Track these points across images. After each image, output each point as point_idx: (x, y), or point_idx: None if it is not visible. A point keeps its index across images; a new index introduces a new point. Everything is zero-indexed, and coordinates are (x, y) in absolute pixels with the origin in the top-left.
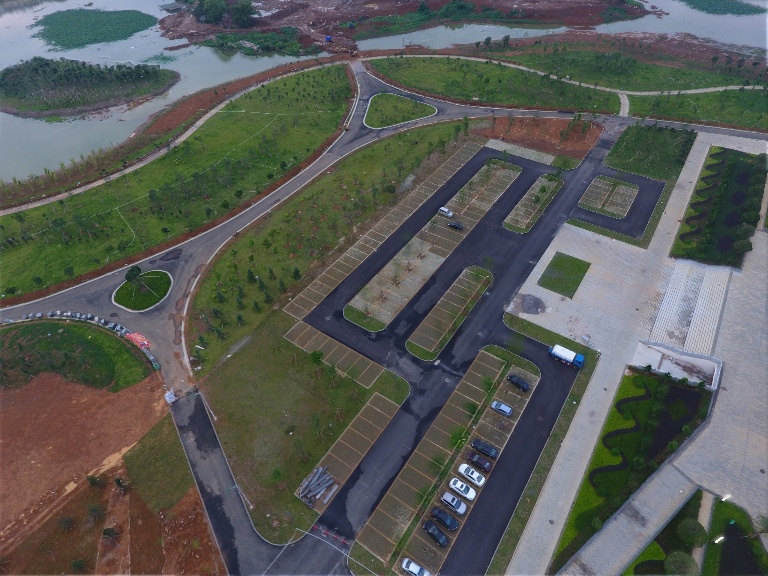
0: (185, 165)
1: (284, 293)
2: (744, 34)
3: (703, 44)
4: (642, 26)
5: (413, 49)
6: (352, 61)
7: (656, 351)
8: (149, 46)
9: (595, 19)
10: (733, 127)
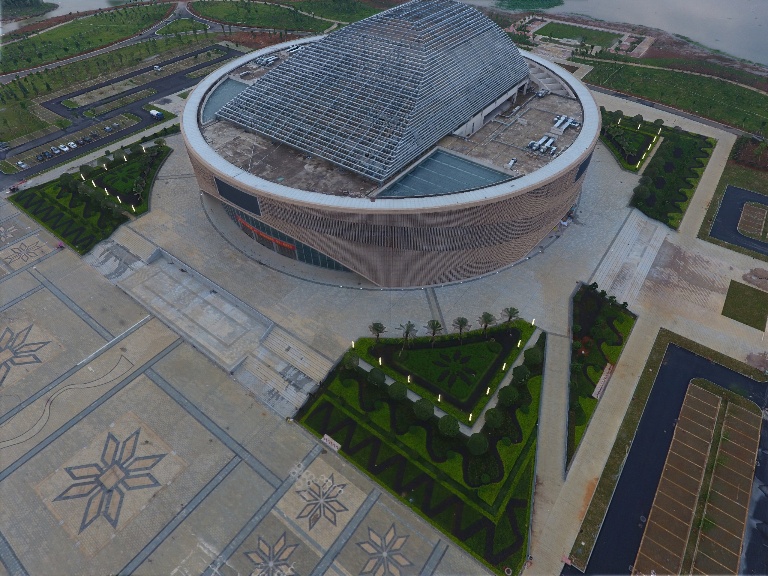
0: None
1: (37, 95)
2: None
3: None
4: None
5: None
6: (182, 2)
7: None
8: None
9: None
10: None
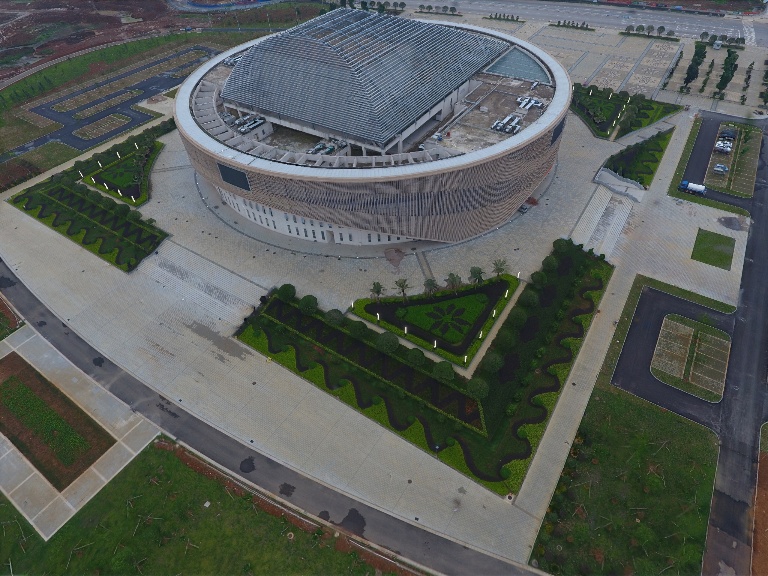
0: None
1: None
2: None
3: None
4: None
5: None
6: None
7: None
8: None
9: None
10: None
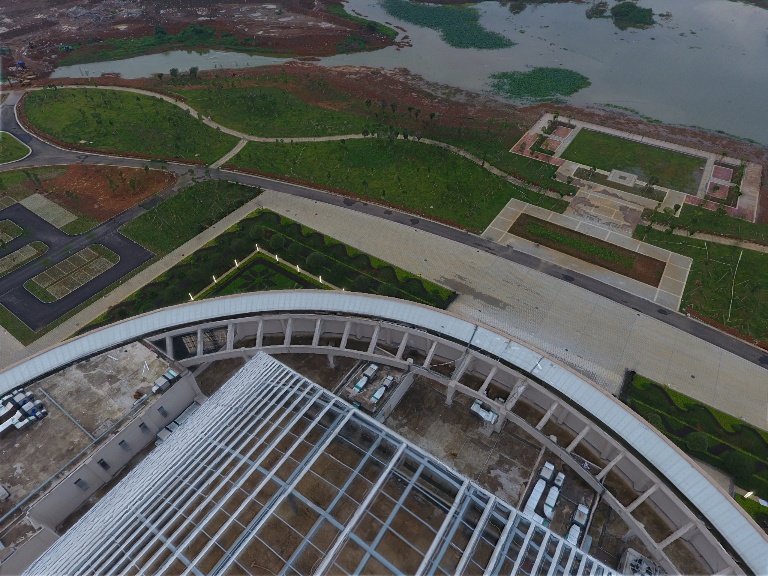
0: None
1: None
2: (456, 72)
3: (406, 82)
4: None
5: None
6: (18, 91)
7: None
8: None
9: (326, 49)
10: (309, 185)
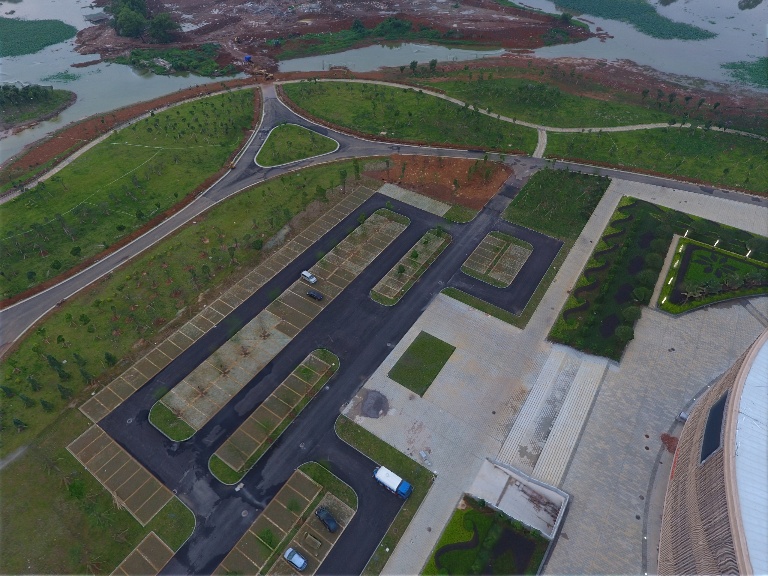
0: (37, 210)
1: (89, 385)
2: (685, 62)
3: (641, 73)
4: (583, 50)
5: (335, 72)
6: (266, 85)
7: (503, 473)
8: (56, 62)
9: (535, 42)
10: (651, 173)
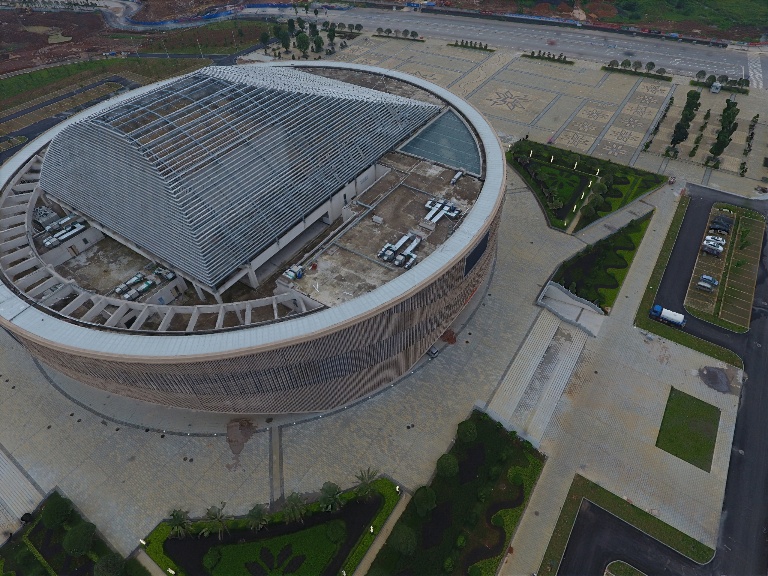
0: None
1: None
2: None
3: None
4: None
5: None
6: None
7: None
8: None
9: None
10: None
